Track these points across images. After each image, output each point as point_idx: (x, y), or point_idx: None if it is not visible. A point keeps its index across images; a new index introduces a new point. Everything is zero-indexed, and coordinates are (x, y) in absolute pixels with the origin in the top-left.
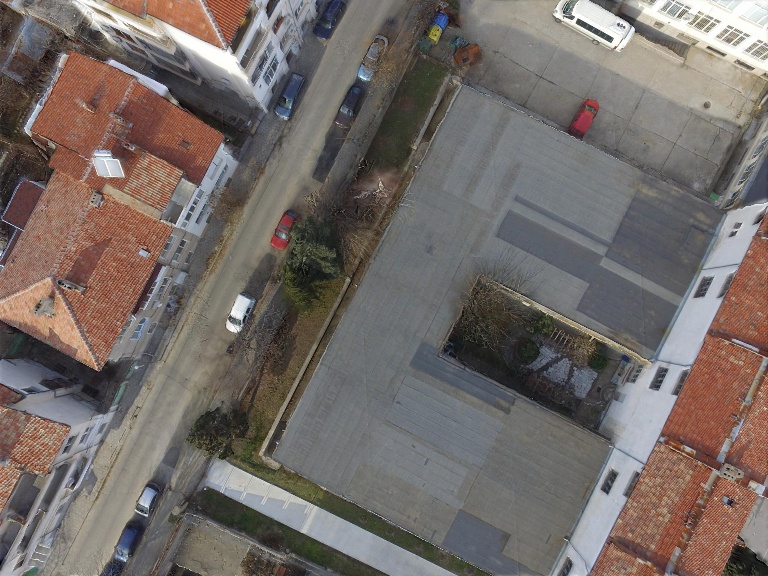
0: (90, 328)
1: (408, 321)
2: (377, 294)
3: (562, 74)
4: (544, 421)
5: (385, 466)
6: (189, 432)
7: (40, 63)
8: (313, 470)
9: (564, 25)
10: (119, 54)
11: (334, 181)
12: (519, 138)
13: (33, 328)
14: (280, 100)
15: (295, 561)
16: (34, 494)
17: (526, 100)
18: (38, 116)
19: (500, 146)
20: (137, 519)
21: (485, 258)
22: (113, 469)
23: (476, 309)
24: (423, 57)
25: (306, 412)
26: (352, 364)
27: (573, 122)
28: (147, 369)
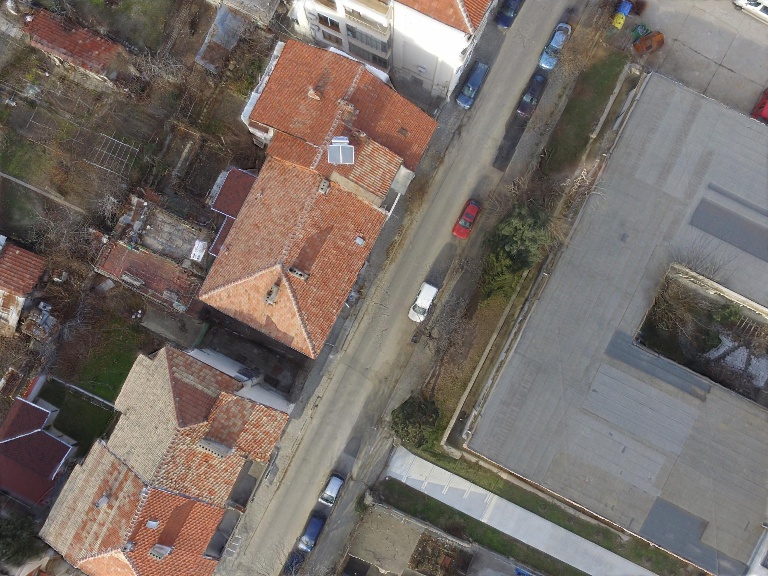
0: (309, 316)
1: (602, 309)
2: (570, 282)
3: (741, 62)
4: (740, 408)
5: (582, 454)
6: (395, 420)
7: (232, 52)
8: (509, 458)
9: (744, 12)
10: (306, 43)
11: (515, 170)
12: (710, 125)
13: (249, 316)
14: (463, 89)
15: (460, 551)
16: (249, 482)
17: (706, 88)
18: (257, 103)
19: (692, 133)
20: (319, 509)
21: (678, 246)
22: (294, 459)
23: (668, 297)
24: (603, 45)
25: (501, 400)
26: (546, 352)
27: (757, 109)
28: (328, 359)
